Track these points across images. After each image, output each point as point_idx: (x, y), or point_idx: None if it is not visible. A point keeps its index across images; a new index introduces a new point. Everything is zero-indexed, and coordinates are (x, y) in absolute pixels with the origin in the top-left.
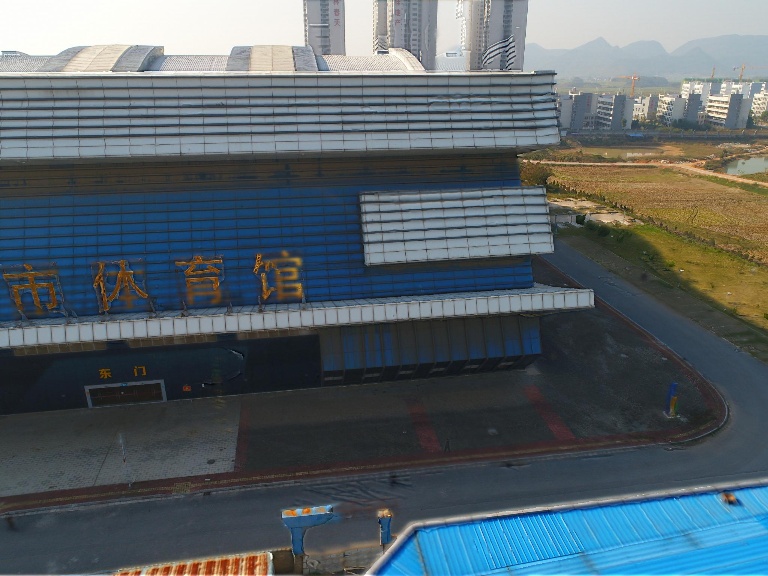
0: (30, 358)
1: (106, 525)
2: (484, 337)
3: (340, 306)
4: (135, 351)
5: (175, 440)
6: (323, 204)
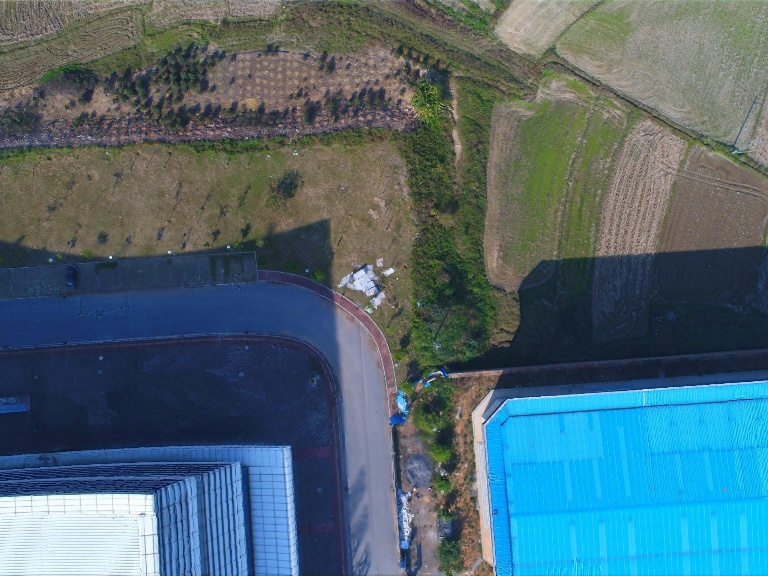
0: None
1: None
2: None
3: None
4: None
5: None
6: None
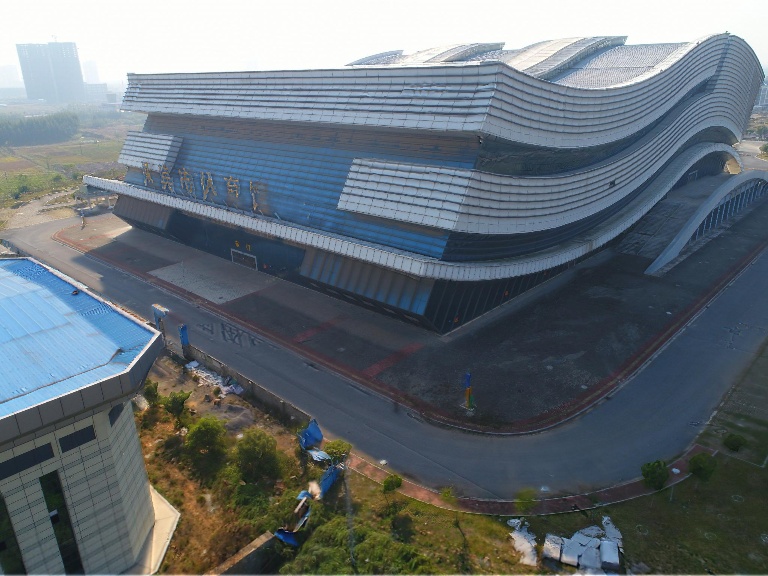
0: (216, 225)
1: (158, 299)
2: (390, 286)
3: None
4: (247, 234)
5: (228, 285)
6: (344, 163)
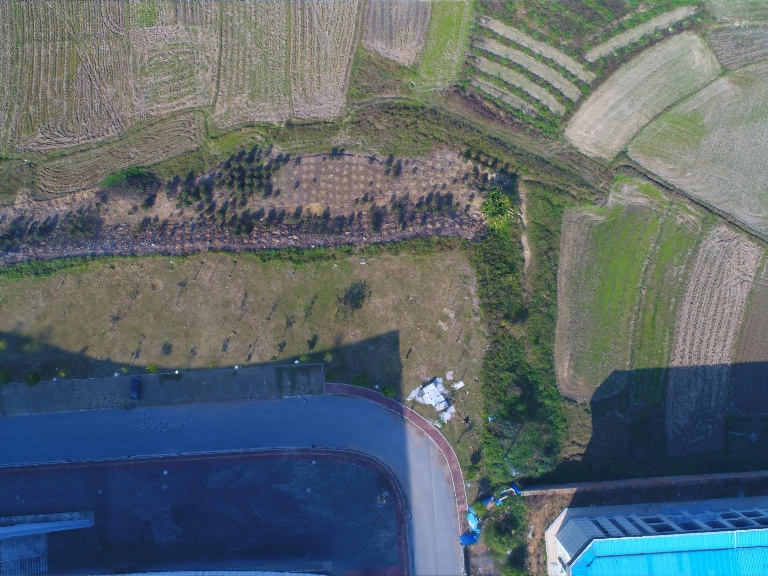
0: None
1: None
2: None
3: None
4: None
5: None
6: None
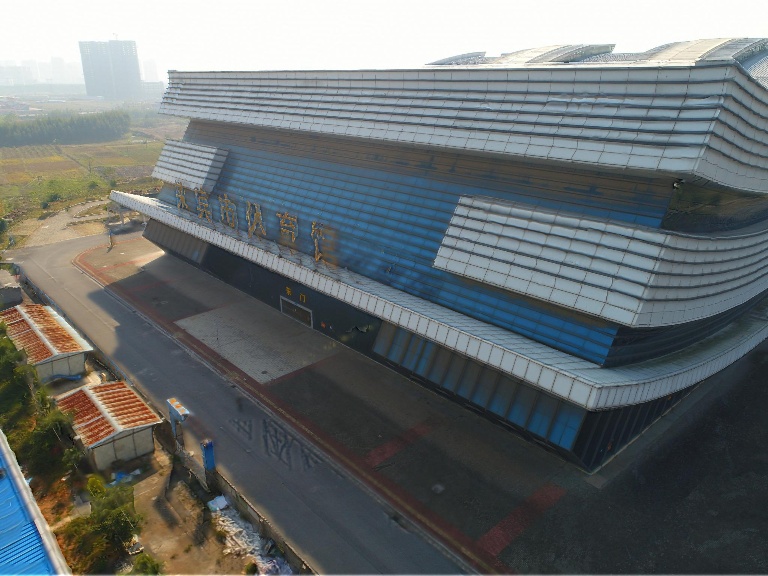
0: None
1: (183, 369)
2: (514, 394)
3: (362, 289)
4: None
5: (275, 351)
6: (442, 199)
